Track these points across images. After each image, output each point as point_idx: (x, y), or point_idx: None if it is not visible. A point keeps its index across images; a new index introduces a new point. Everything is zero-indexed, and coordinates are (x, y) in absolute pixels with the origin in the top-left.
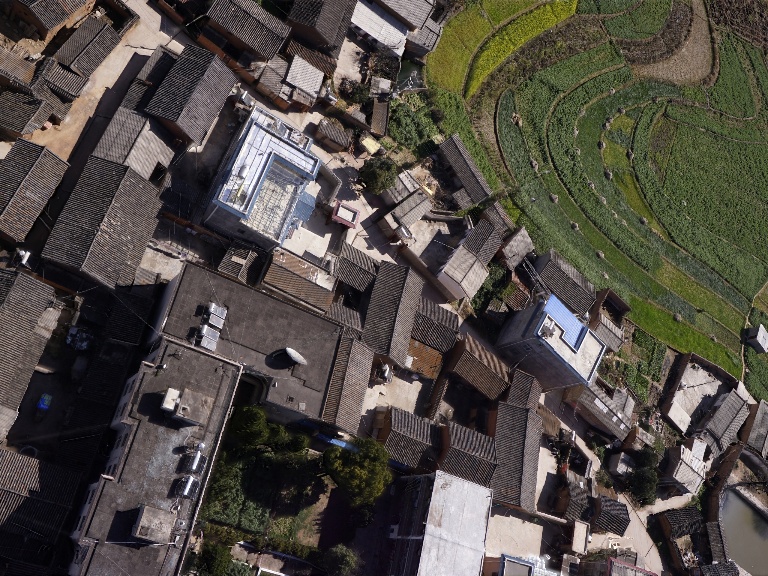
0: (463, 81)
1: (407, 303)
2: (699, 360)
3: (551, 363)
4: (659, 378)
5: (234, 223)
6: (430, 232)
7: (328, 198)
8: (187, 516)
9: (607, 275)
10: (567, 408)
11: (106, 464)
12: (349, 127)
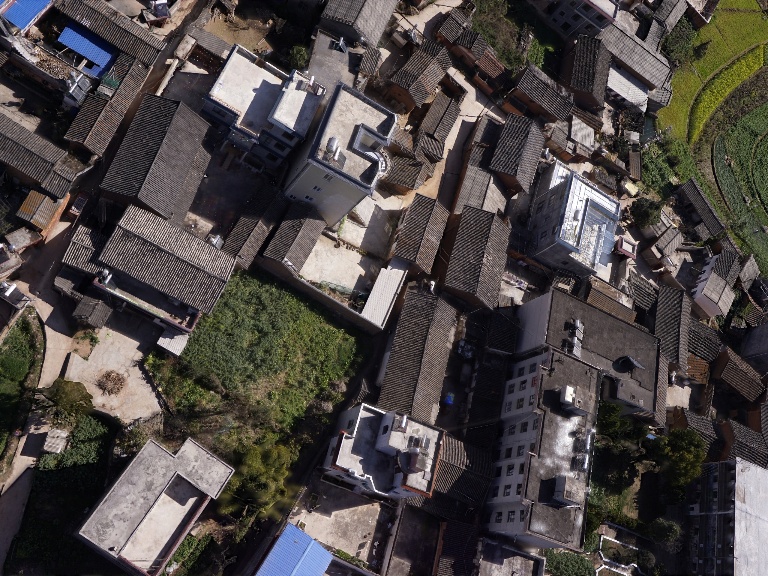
0: (686, 130)
1: (684, 320)
2: None
3: None
4: None
5: (562, 256)
6: (678, 260)
7: None
8: None
9: None
10: None
11: (500, 447)
12: (612, 174)
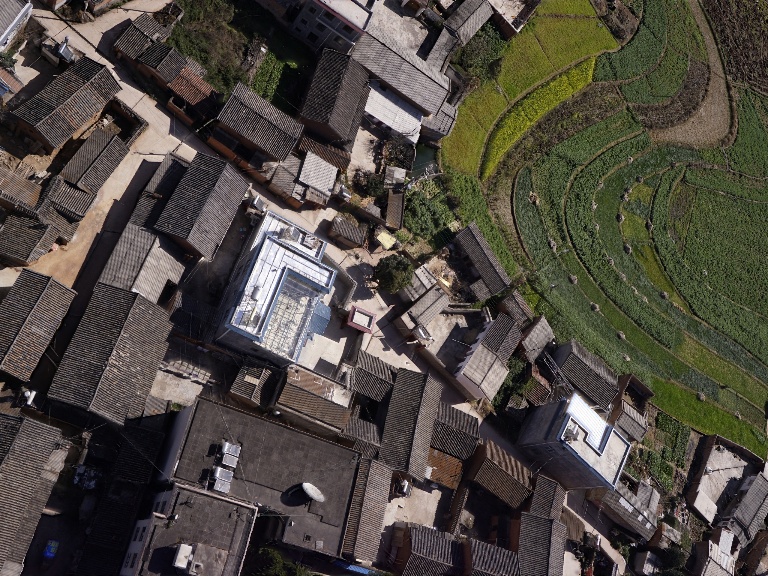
0: (479, 162)
1: (426, 412)
2: (724, 441)
3: (575, 465)
4: (684, 464)
5: (247, 343)
6: (447, 326)
7: (343, 302)
8: None
9: (628, 357)
10: (590, 506)
11: None
12: (363, 221)
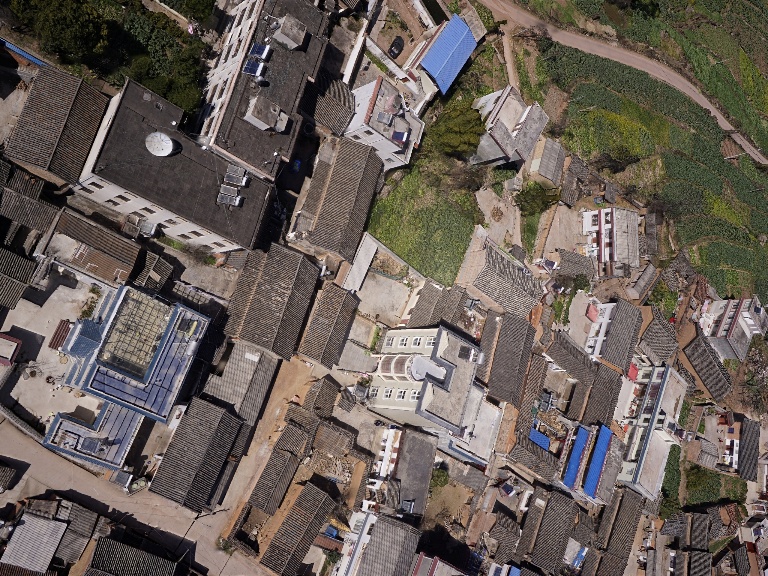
0: None
1: None
2: None
3: None
4: None
5: None
6: None
7: None
8: (258, 32)
9: None
10: None
11: None
12: None
